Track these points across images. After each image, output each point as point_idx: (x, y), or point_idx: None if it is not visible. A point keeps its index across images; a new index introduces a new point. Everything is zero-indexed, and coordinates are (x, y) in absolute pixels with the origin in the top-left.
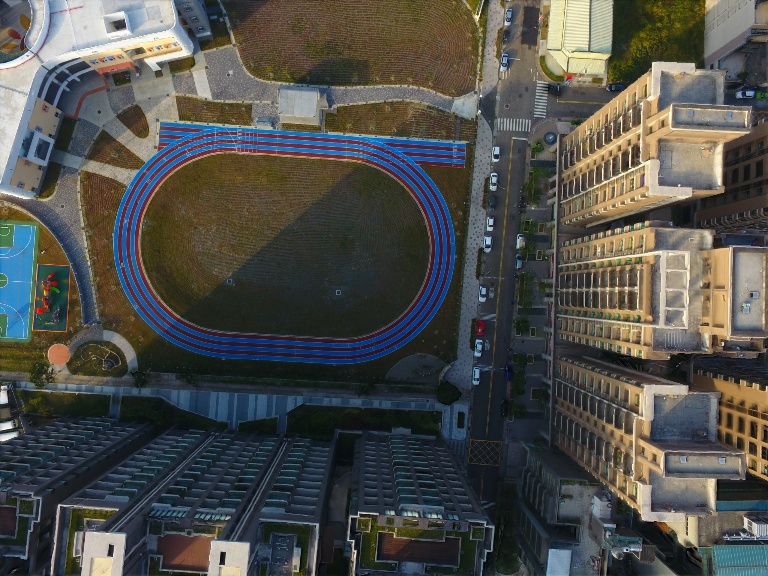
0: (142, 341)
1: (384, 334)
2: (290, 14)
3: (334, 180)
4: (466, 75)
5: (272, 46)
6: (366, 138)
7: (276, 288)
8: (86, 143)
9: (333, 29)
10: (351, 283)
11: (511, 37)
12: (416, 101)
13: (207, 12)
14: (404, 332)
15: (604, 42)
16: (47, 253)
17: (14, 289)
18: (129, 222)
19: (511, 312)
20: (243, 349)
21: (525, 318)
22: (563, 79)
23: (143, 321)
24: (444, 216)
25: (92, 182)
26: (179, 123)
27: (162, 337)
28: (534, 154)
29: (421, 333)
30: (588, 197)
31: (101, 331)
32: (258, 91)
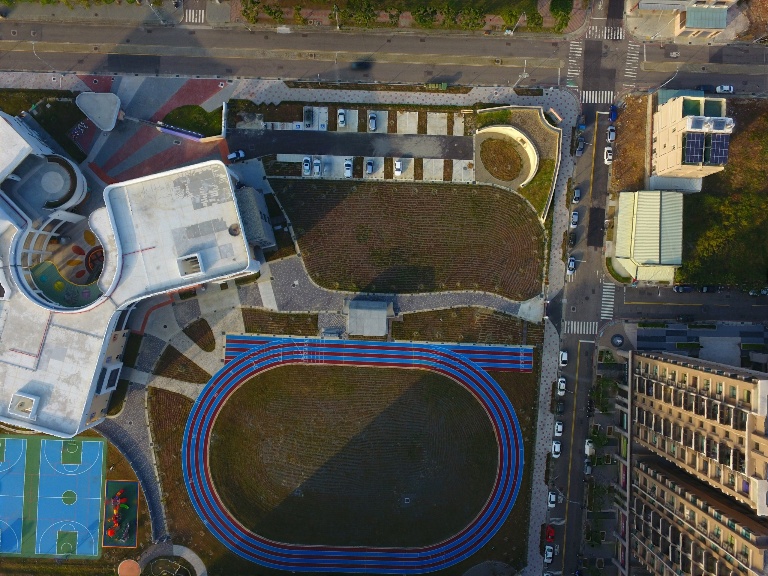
0: (212, 555)
1: (454, 543)
2: (355, 222)
3: (401, 388)
4: (532, 279)
5: (337, 255)
6: (433, 345)
7: (345, 498)
8: (153, 358)
9: (398, 236)
10: (420, 491)
11: (577, 239)
12: (482, 306)
13: (271, 223)
14: (474, 540)
15: (674, 253)
16: (115, 469)
17: (83, 506)
18: (197, 437)
19: (580, 516)
20: (313, 562)
21: (594, 522)
22: (630, 280)
23: (213, 536)
24: (512, 422)
25: (159, 398)
26: (245, 335)
27: (232, 552)
28: (602, 357)
29: (491, 541)
30: (670, 442)
31: (171, 546)
32: (324, 301)
